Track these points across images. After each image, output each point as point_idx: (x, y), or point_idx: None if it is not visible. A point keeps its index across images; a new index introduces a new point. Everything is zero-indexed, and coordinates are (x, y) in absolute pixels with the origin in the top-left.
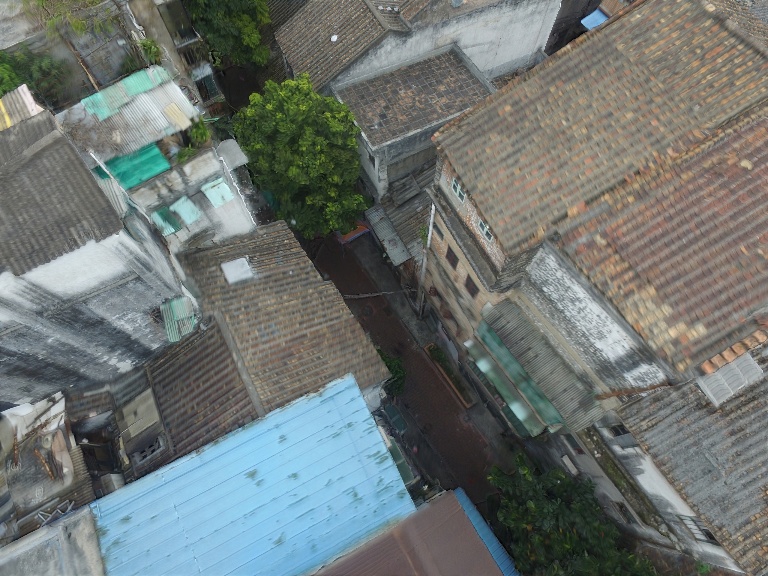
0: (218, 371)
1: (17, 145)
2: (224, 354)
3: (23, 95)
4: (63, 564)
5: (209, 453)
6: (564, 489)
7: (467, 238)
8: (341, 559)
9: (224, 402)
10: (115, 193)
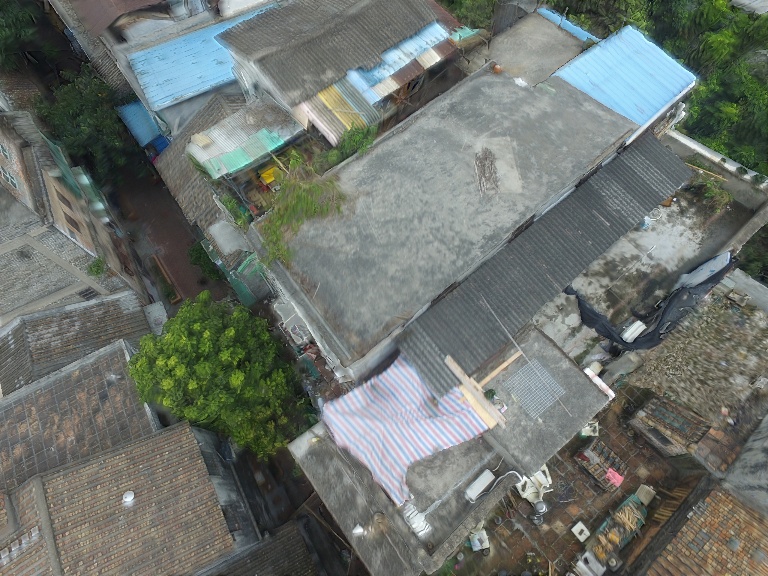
0: None
1: (295, 68)
2: None
3: (326, 129)
4: None
5: None
6: (75, 150)
7: (33, 181)
8: (148, 4)
9: None
10: (241, 80)
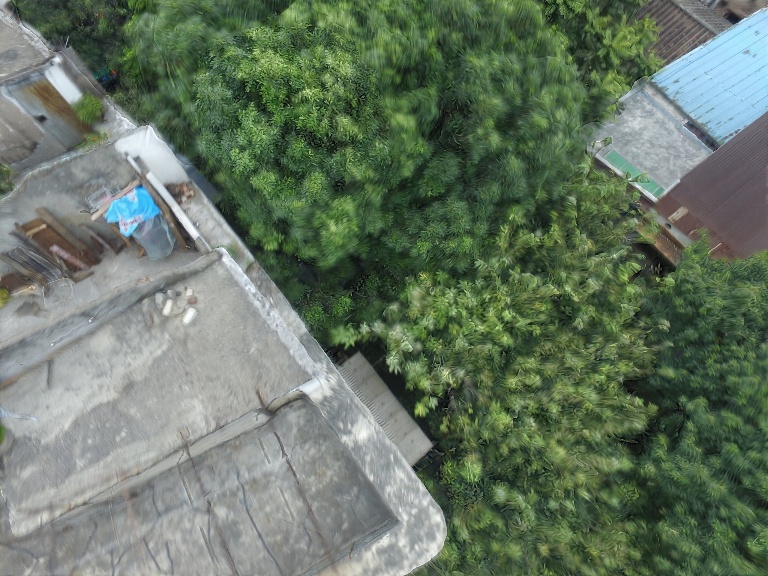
0: (667, 21)
1: None
2: (670, 9)
3: None
4: (655, 102)
5: (711, 45)
6: None
7: None
8: None
9: (679, 39)
10: None
